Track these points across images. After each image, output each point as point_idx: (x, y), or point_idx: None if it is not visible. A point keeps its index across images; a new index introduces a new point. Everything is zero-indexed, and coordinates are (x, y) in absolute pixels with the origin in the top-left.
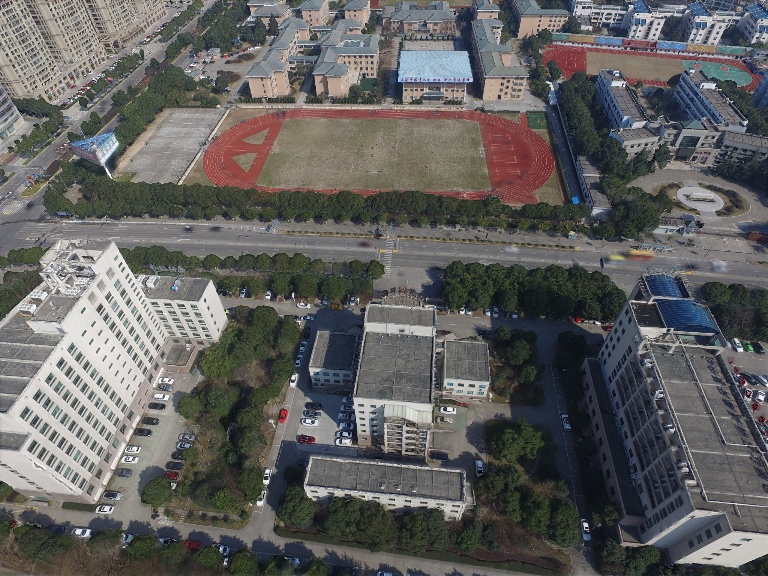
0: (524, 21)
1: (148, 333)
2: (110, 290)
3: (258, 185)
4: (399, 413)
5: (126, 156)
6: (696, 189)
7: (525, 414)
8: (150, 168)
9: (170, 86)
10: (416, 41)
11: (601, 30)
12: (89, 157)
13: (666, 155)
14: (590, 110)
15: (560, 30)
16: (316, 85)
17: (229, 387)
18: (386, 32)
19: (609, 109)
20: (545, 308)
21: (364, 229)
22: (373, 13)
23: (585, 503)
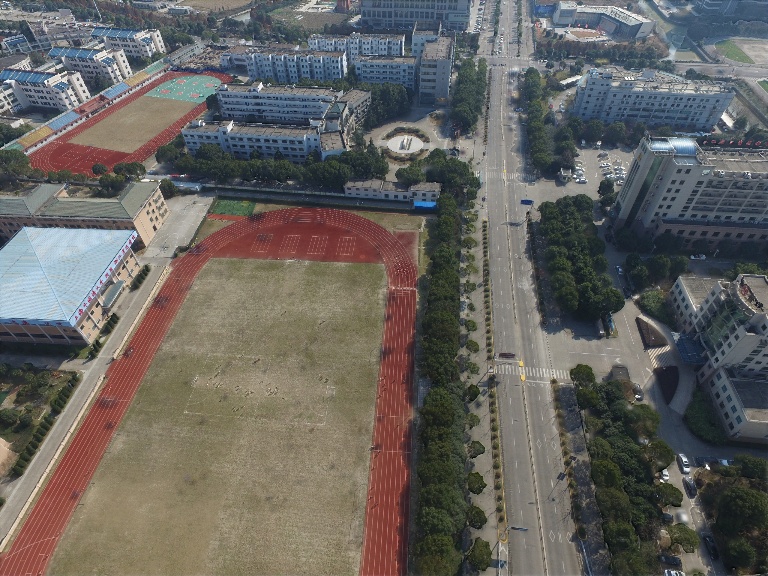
0: None
1: None
2: None
3: None
4: None
5: None
6: (392, 142)
7: None
8: None
9: None
10: None
11: None
12: None
13: None
14: None
15: None
16: None
17: None
18: None
19: (259, 148)
20: None
21: (478, 401)
22: None
23: (758, 260)
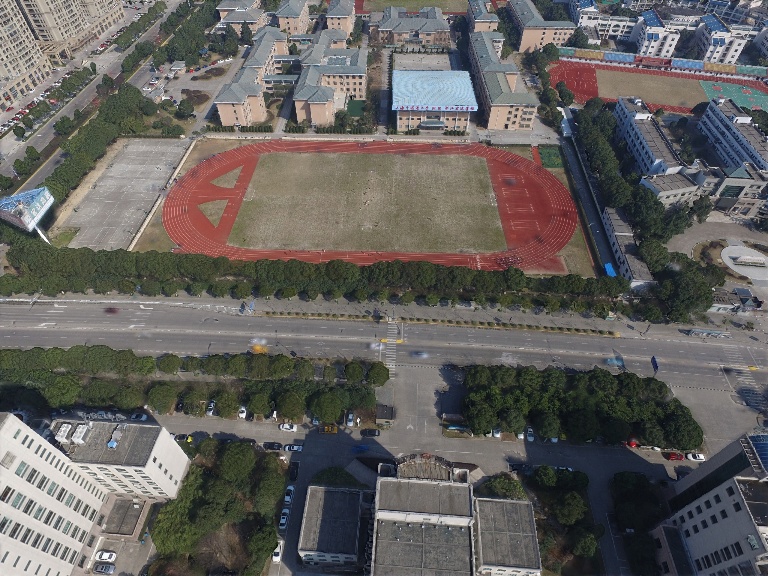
0: (526, 33)
1: (76, 505)
2: (8, 483)
3: (230, 245)
4: None
5: (69, 204)
6: (742, 249)
7: None
8: (97, 221)
9: (124, 112)
10: (407, 54)
11: (608, 43)
12: (14, 221)
13: (707, 209)
14: (610, 145)
15: (565, 44)
16: (297, 111)
17: (191, 568)
18: (373, 42)
19: (634, 146)
20: (595, 436)
21: (360, 308)
22: (358, 20)
23: None
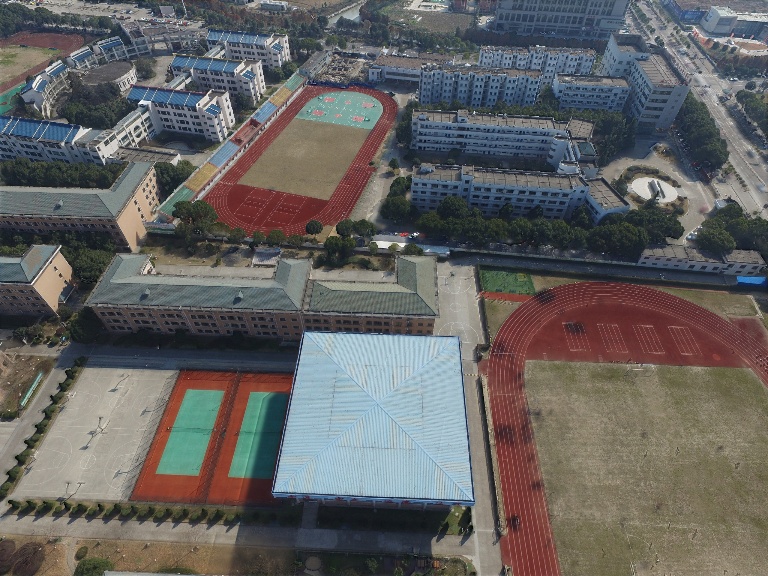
0: (122, 223)
1: None
2: None
3: None
4: None
5: None
6: (637, 187)
7: None
8: None
9: None
10: (33, 461)
11: None
12: None
13: None
14: None
15: (158, 190)
16: None
17: None
18: None
19: (507, 200)
20: None
21: None
22: None
23: None
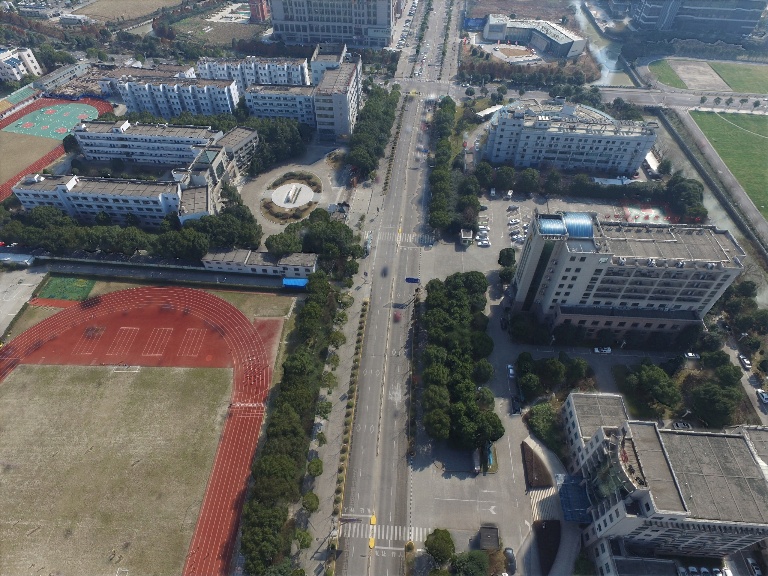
0: None
1: None
2: None
3: None
4: (767, 473)
5: None
6: (277, 193)
7: (605, 381)
8: None
9: None
10: None
11: None
12: None
13: (236, 191)
14: None
15: None
16: None
17: None
18: None
19: (109, 209)
20: None
21: None
22: None
23: (670, 352)
